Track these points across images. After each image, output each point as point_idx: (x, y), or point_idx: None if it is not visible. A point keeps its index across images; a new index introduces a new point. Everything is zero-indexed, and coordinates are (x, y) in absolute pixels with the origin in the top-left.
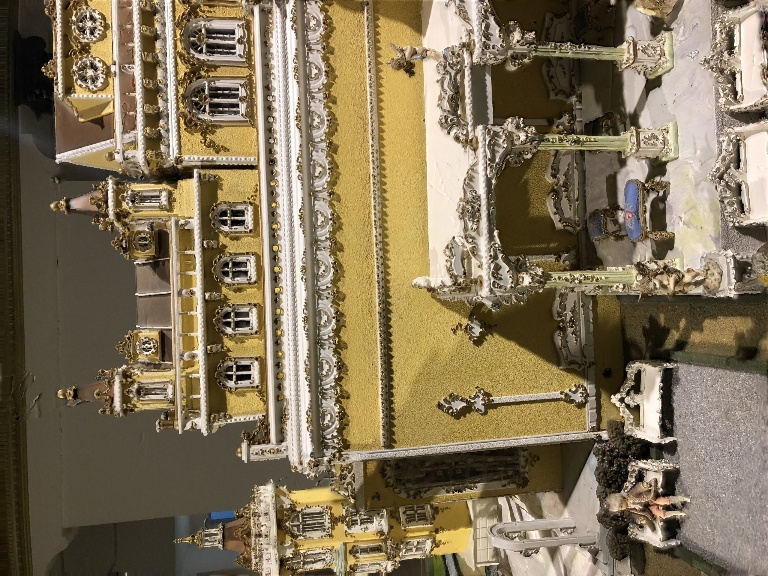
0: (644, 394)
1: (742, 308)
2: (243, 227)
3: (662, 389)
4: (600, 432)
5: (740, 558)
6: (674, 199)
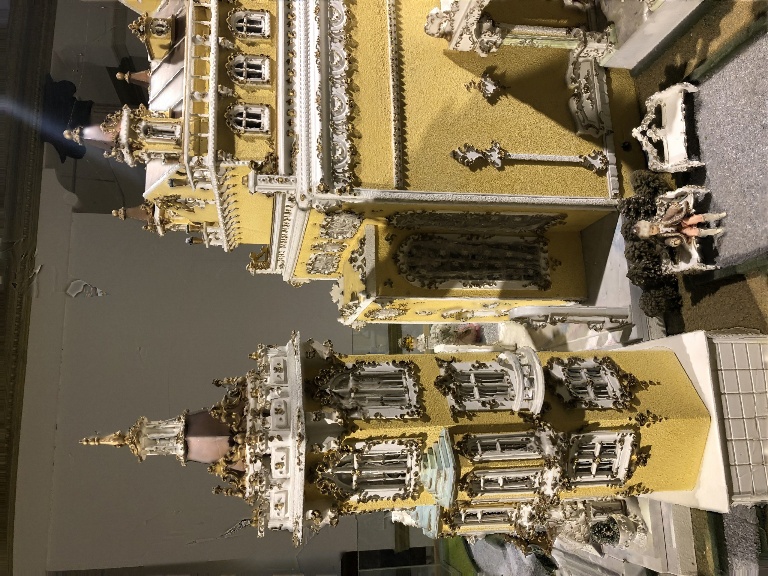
0: (666, 129)
1: None
2: None
3: (685, 122)
4: (624, 198)
5: None
6: None
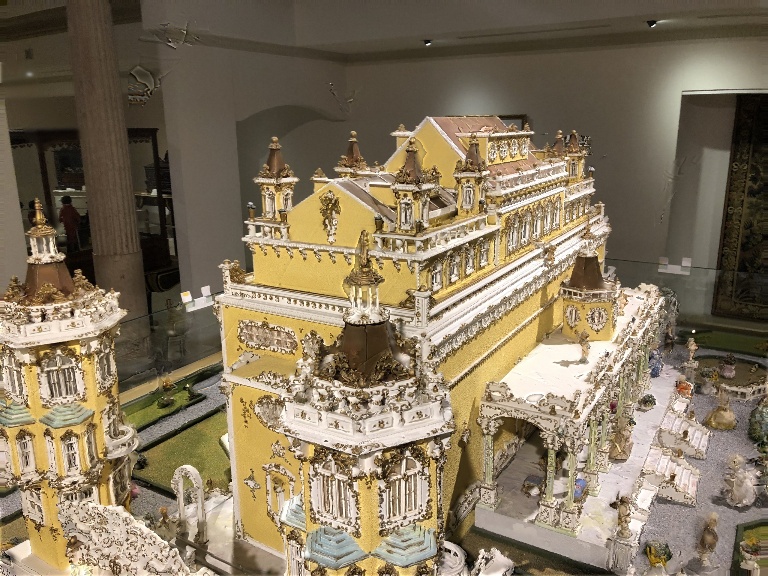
0: (485, 571)
1: (582, 574)
2: None
3: None
4: None
5: None
6: (586, 507)
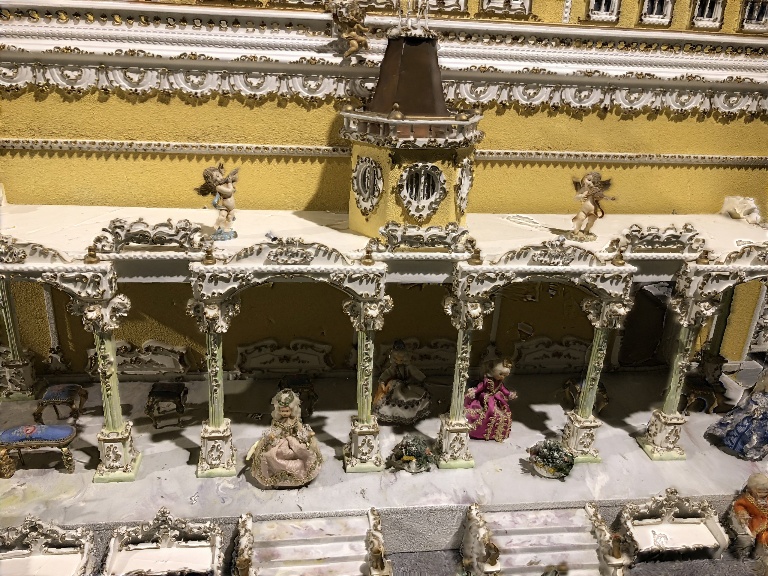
0: None
1: None
2: None
3: None
4: None
5: None
6: (50, 478)
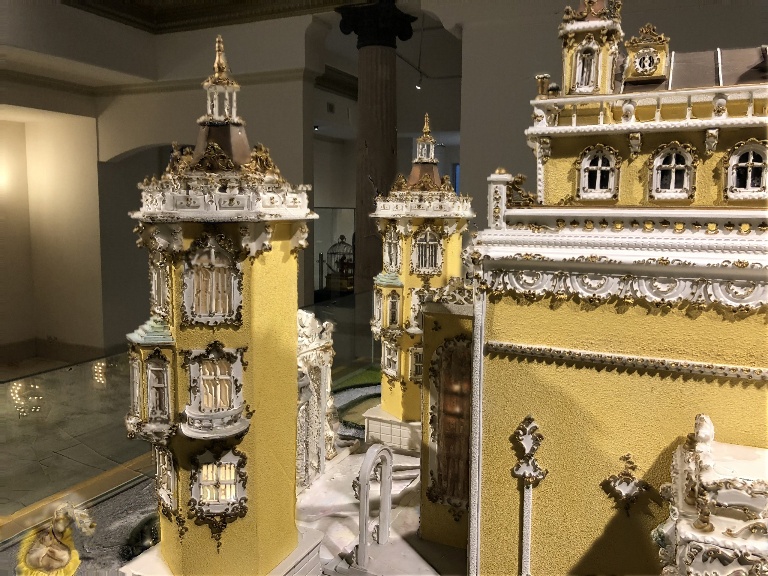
0: None
1: None
2: None
3: None
4: None
5: None
6: None
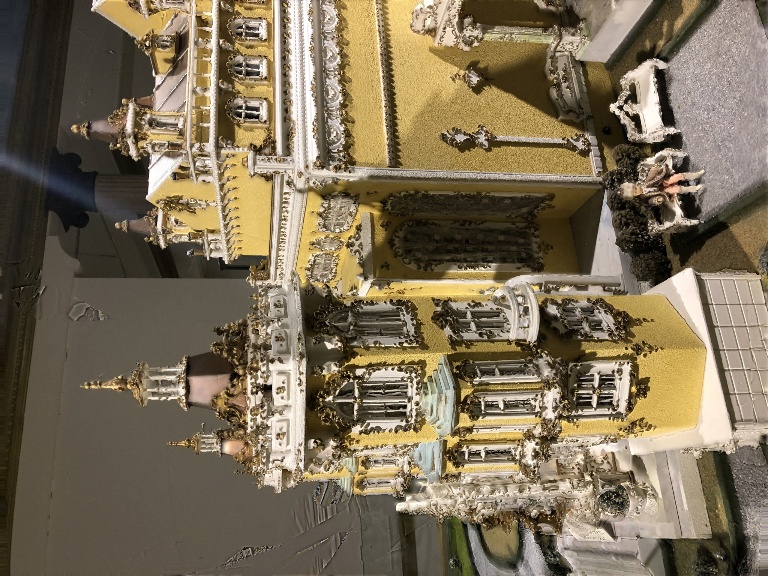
0: (642, 104)
1: None
2: (257, 0)
3: None
4: None
5: (761, 164)
6: None
